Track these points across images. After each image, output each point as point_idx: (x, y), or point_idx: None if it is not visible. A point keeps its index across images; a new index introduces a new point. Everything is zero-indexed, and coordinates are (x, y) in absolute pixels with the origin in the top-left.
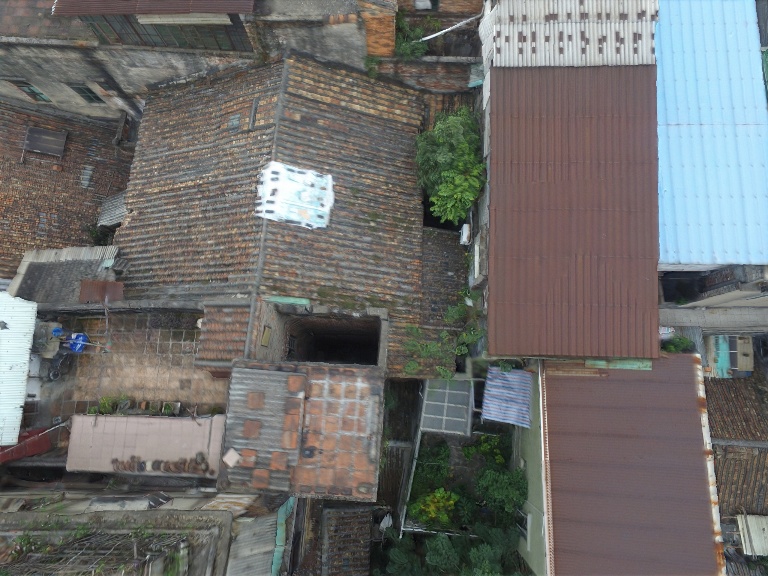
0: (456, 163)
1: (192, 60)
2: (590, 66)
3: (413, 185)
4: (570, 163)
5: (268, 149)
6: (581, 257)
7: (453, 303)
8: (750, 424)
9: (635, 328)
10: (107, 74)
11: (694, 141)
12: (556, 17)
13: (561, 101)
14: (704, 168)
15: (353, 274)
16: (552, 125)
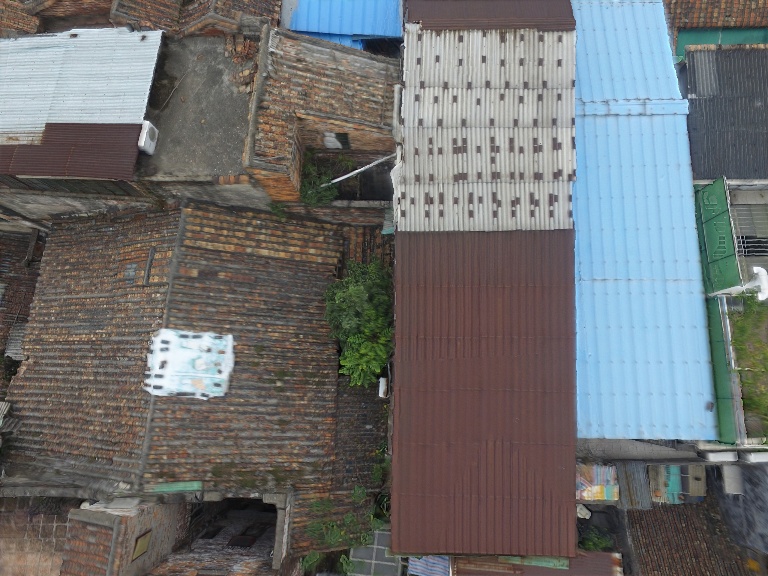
0: (362, 328)
1: (87, 202)
2: (502, 231)
3: (328, 332)
4: (481, 338)
5: (160, 312)
6: (492, 443)
7: (371, 460)
8: (700, 561)
9: (550, 524)
10: (4, 207)
11: (622, 298)
12: (465, 176)
13: (471, 268)
14: (632, 329)
15: (255, 444)
16: (462, 295)
